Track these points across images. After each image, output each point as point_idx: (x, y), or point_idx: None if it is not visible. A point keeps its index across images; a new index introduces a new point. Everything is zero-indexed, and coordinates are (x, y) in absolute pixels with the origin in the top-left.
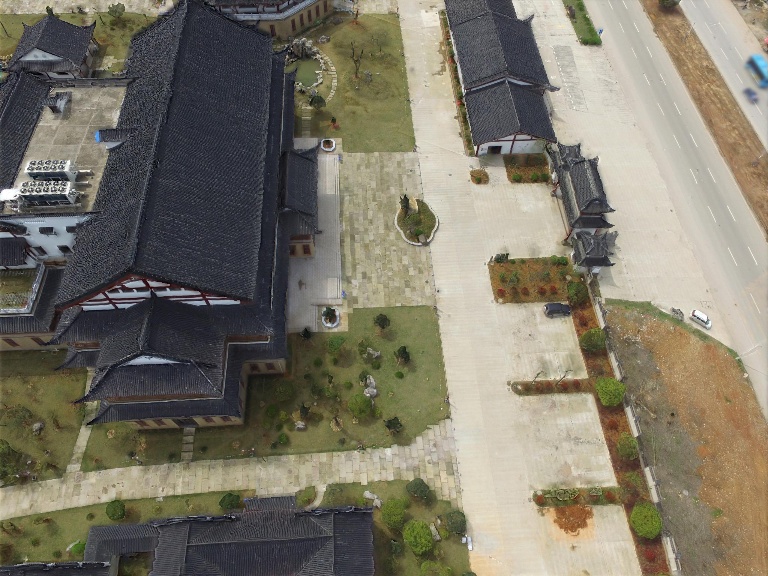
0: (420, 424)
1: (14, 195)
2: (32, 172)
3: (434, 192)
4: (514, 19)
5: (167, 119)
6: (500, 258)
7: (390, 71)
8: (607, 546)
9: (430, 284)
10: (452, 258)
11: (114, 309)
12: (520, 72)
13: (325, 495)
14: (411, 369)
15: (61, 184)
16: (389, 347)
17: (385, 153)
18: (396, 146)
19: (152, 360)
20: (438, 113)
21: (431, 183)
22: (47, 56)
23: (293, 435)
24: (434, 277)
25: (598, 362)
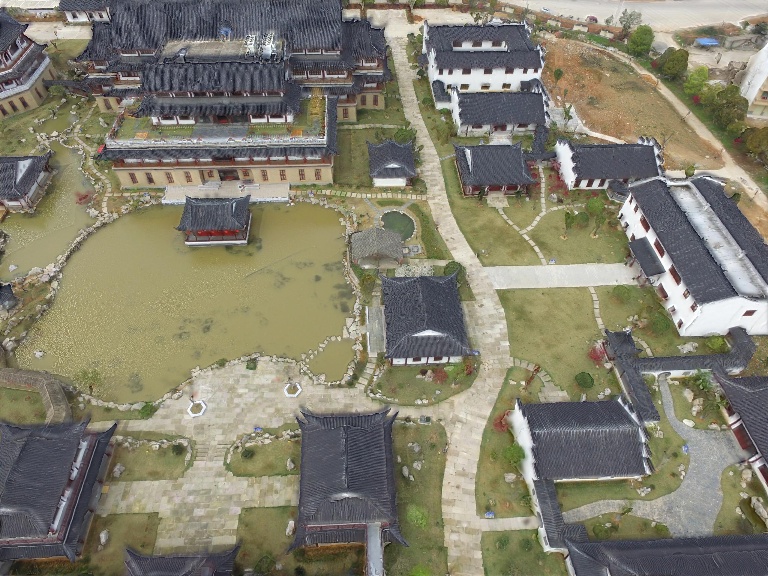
0: None
1: (269, 51)
2: None
3: None
4: None
5: None
6: None
7: None
8: (427, 14)
9: None
10: None
11: None
12: None
13: (414, 63)
14: None
15: (267, 35)
16: None
17: None
18: None
19: None
20: None
21: None
22: (25, 165)
23: None
24: None
25: (353, 6)
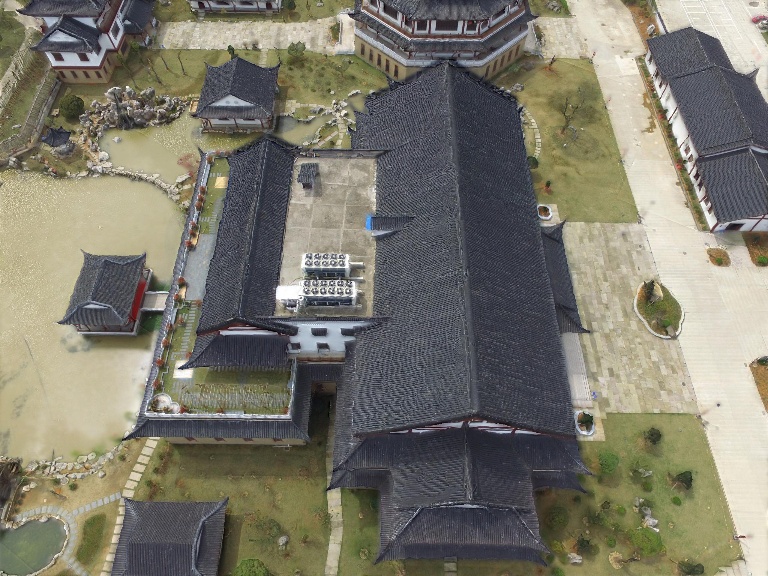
0: (710, 565)
1: (294, 294)
2: (310, 267)
3: (671, 273)
4: (739, 74)
5: (462, 213)
6: (765, 360)
7: (595, 126)
8: None
9: (688, 387)
10: (707, 356)
11: (407, 432)
12: (763, 139)
13: None
14: (688, 494)
15: (346, 284)
16: (657, 464)
17: (607, 224)
18: (618, 216)
19: (469, 505)
20: (657, 178)
21: (665, 262)
22: (239, 102)
23: (567, 569)
24: (691, 378)
25: None
